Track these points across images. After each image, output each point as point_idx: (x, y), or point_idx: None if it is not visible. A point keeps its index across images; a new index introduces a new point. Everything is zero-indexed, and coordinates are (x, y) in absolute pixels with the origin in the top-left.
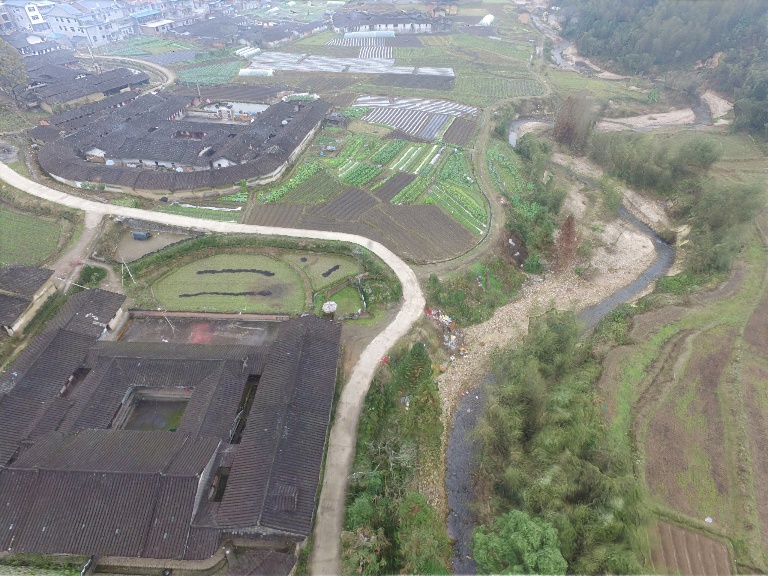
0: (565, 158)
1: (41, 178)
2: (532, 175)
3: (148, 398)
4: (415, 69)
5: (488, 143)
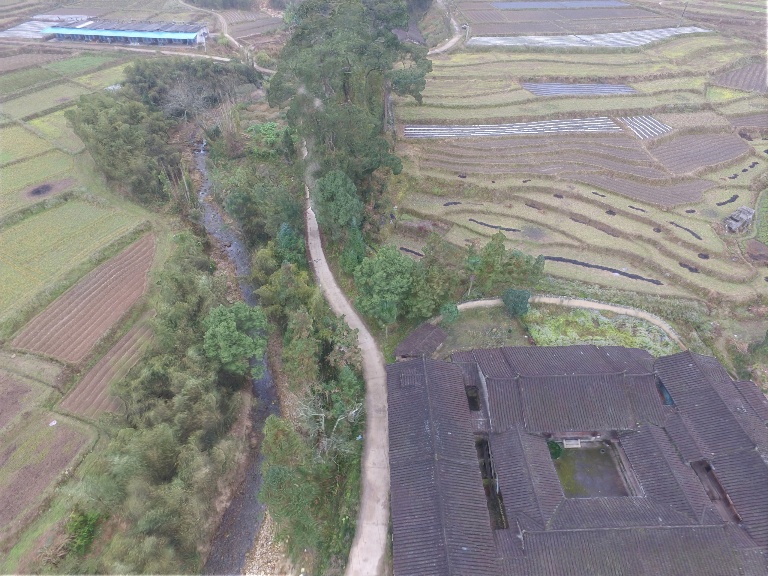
0: None
1: None
2: None
3: None
4: None
5: None
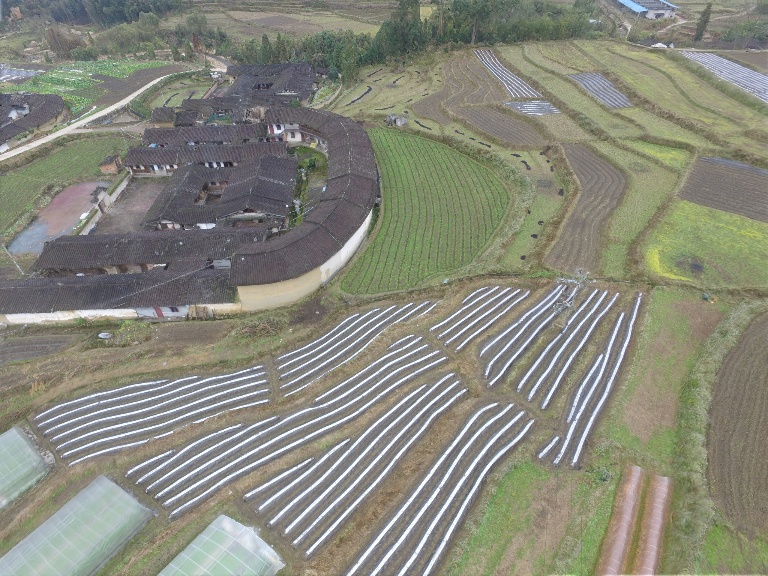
0: None
1: None
2: (120, 57)
3: None
4: None
5: None
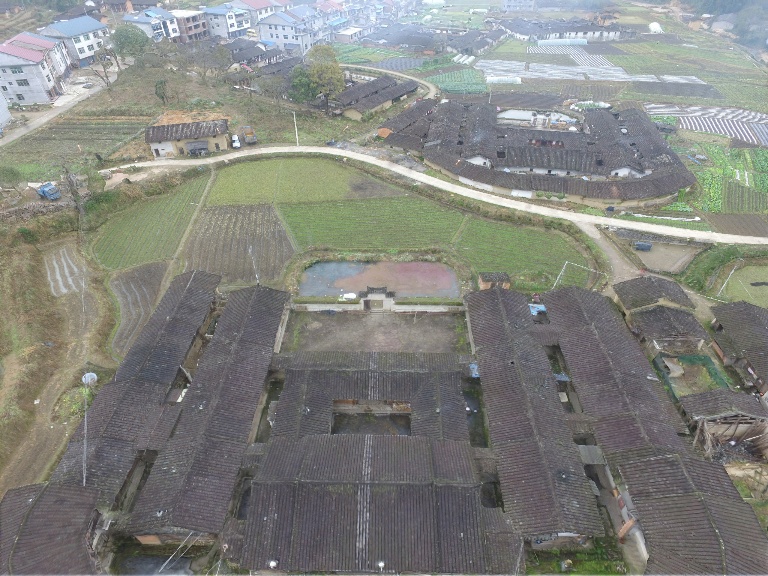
0: None
1: (470, 186)
2: None
3: None
4: (658, 77)
5: None
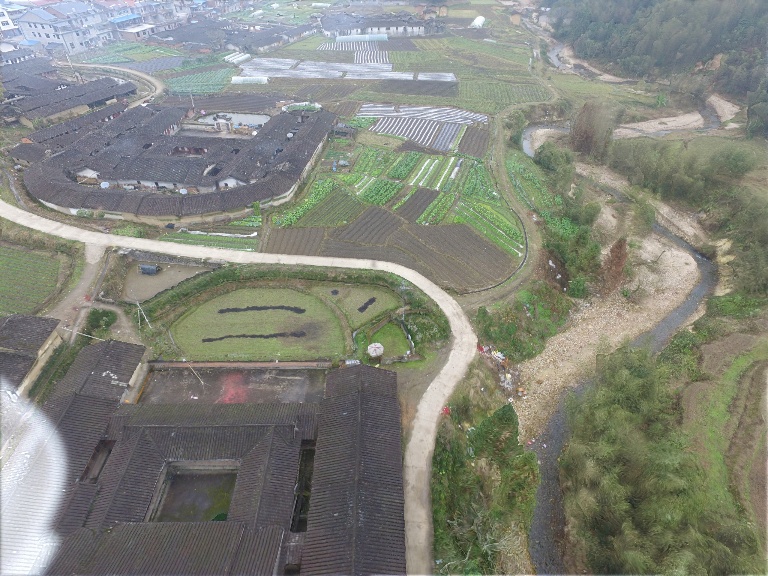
0: (584, 167)
1: (30, 205)
2: (558, 188)
3: (184, 472)
4: (415, 74)
5: (505, 153)
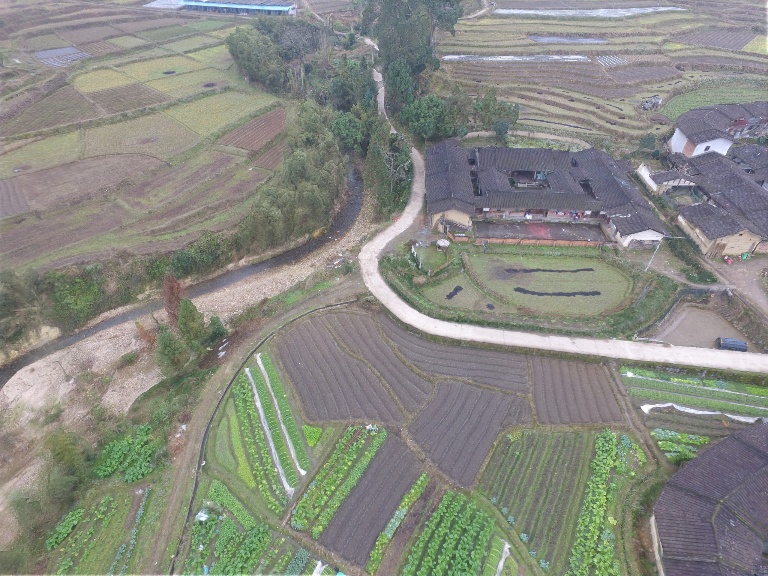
0: None
1: None
2: (26, 568)
3: None
4: None
5: None
